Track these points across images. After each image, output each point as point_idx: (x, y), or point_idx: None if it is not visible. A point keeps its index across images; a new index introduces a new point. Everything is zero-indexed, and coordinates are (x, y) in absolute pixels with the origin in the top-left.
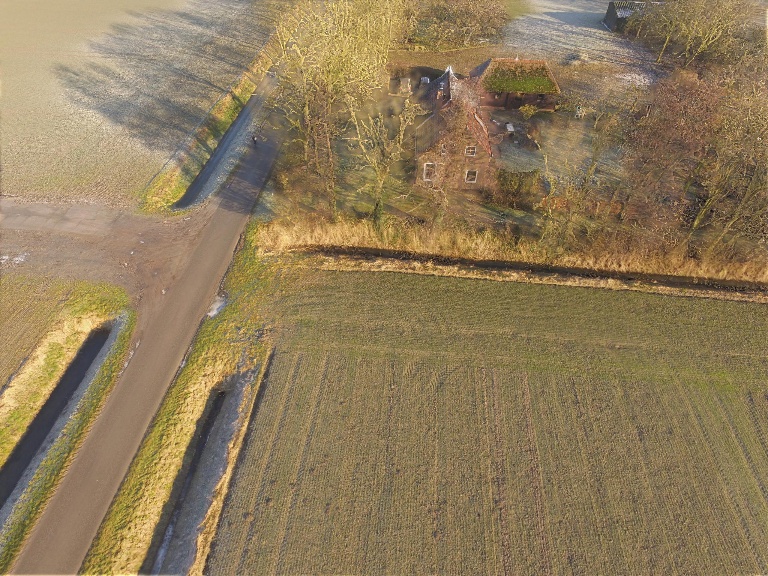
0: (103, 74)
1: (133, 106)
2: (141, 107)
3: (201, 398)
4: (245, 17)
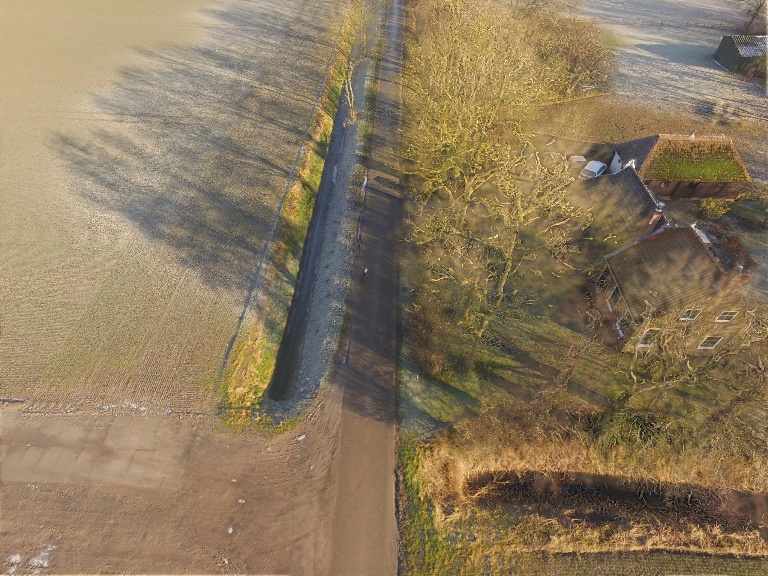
0: (120, 149)
1: (171, 206)
2: (183, 208)
3: None
4: (284, 55)
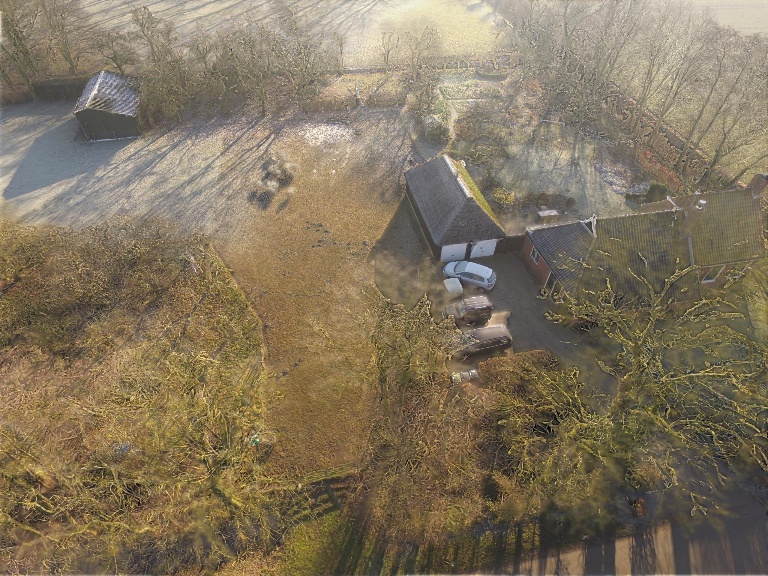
0: None
1: None
2: None
3: None
4: None
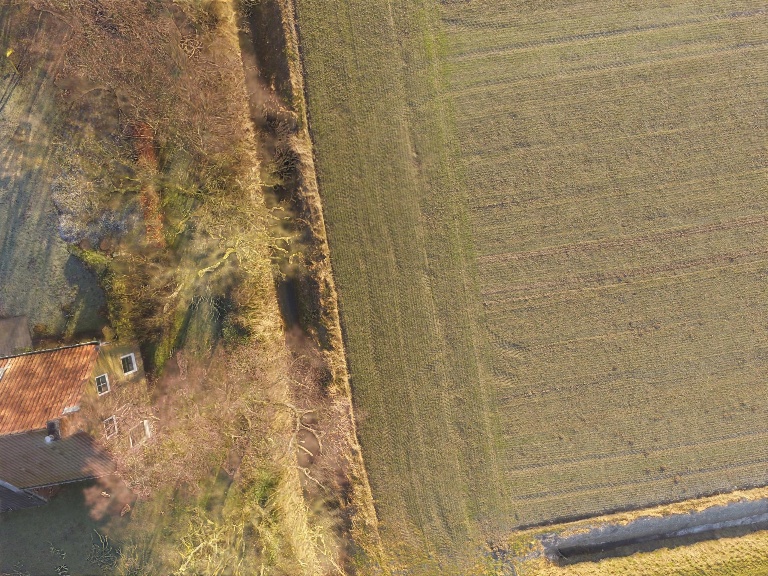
0: None
1: None
2: None
3: (576, 572)
4: None
